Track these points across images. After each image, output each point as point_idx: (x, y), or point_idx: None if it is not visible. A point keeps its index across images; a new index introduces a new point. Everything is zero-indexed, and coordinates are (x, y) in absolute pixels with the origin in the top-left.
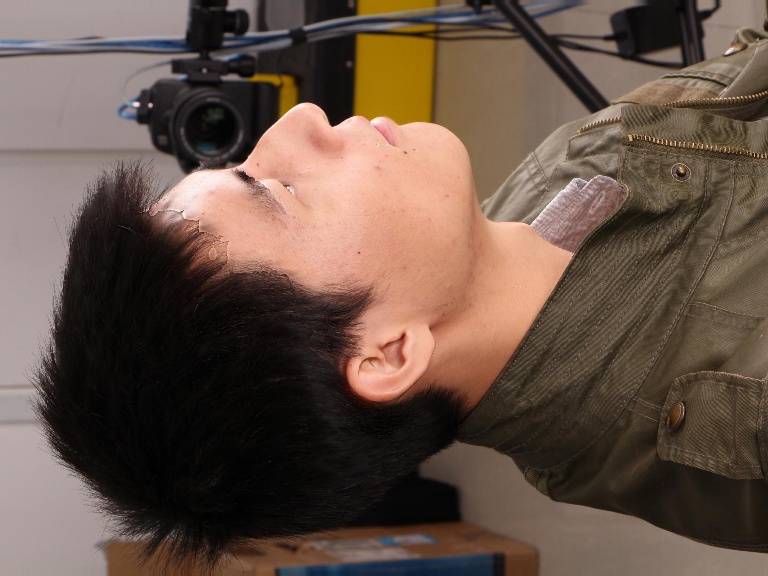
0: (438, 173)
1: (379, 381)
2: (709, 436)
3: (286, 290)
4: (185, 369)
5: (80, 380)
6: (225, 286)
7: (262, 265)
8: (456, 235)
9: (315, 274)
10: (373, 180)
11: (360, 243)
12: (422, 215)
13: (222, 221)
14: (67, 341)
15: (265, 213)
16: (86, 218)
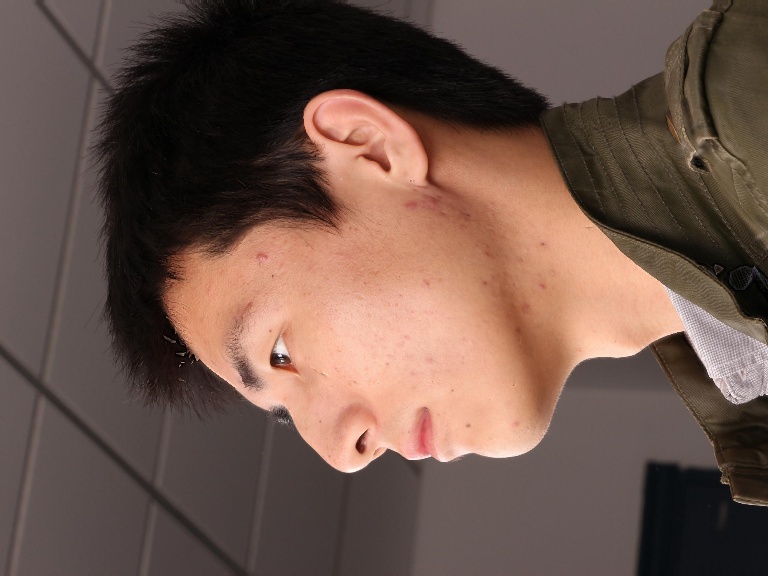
0: None
1: None
2: None
3: None
4: None
5: (145, 102)
6: None
7: None
8: None
9: None
10: None
11: None
12: None
13: None
14: (123, 153)
15: None
16: None
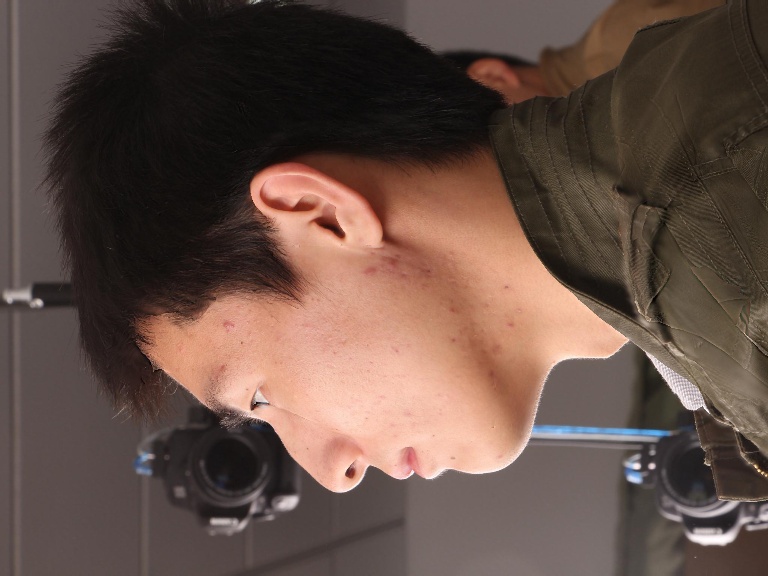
0: None
1: None
2: None
3: None
4: None
5: (88, 160)
6: None
7: None
8: None
9: None
10: None
11: None
12: None
13: None
14: (73, 209)
15: None
16: None
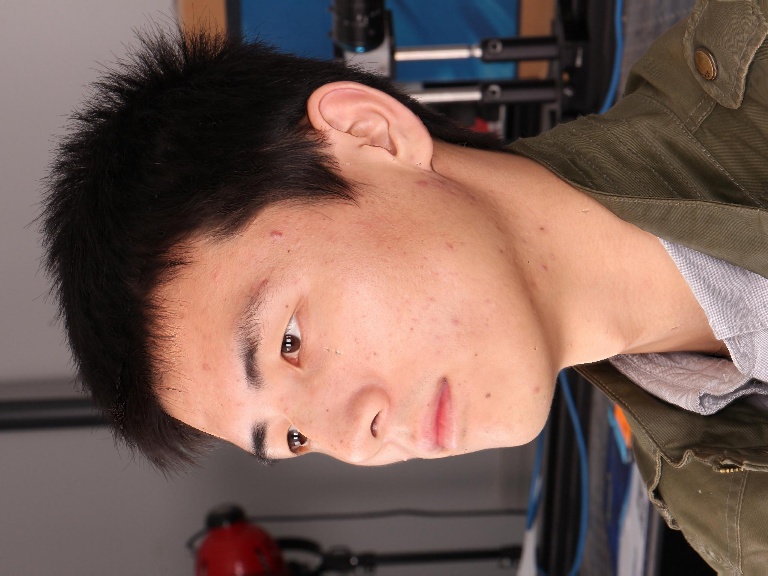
0: None
1: None
2: None
3: None
4: None
5: (125, 119)
6: None
7: None
8: None
9: None
10: None
11: None
12: None
13: None
14: (105, 166)
15: None
16: (88, 383)
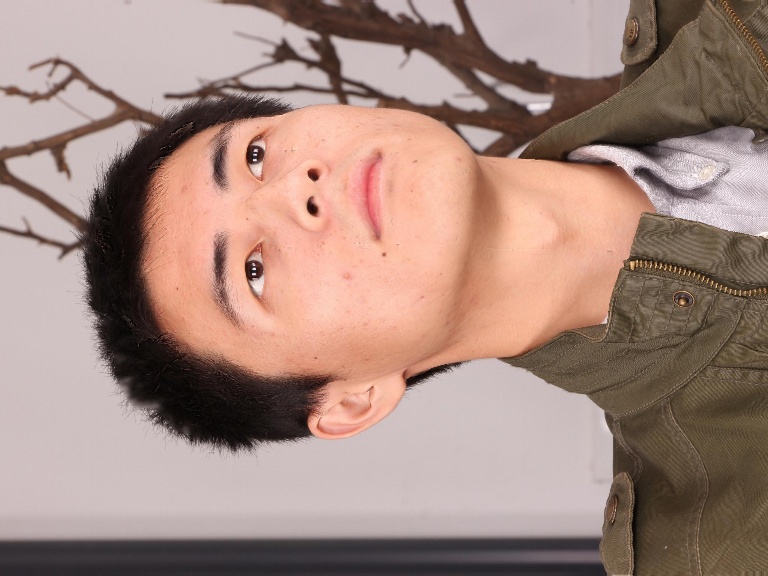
0: (416, 275)
1: (341, 424)
2: (615, 571)
3: (236, 393)
4: (156, 410)
5: None
6: (186, 371)
7: (222, 356)
8: (427, 330)
9: (273, 366)
10: (337, 296)
11: (316, 353)
12: (386, 325)
13: (190, 308)
14: None
15: (226, 318)
16: (86, 237)
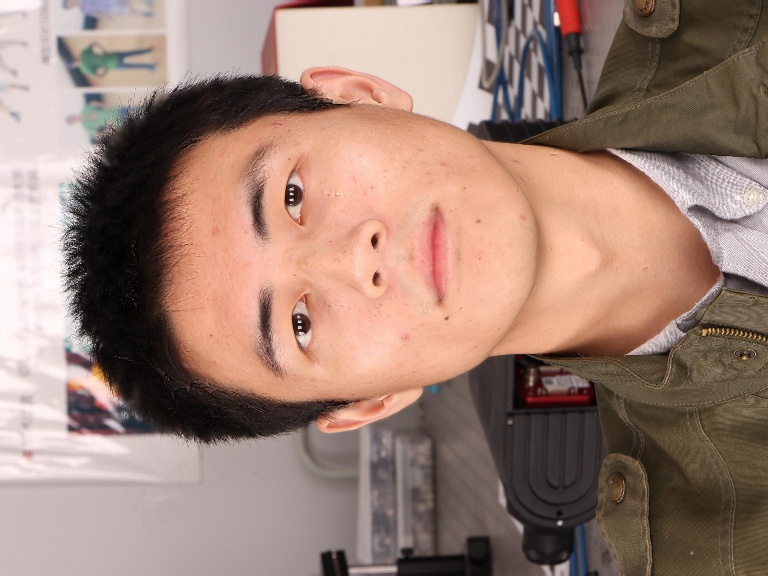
0: (475, 332)
1: None
2: None
3: None
4: None
5: None
6: (208, 401)
7: (251, 391)
8: None
9: (303, 396)
10: (392, 354)
11: (356, 392)
12: (435, 371)
13: (225, 354)
14: (120, 133)
15: None
16: (104, 276)
